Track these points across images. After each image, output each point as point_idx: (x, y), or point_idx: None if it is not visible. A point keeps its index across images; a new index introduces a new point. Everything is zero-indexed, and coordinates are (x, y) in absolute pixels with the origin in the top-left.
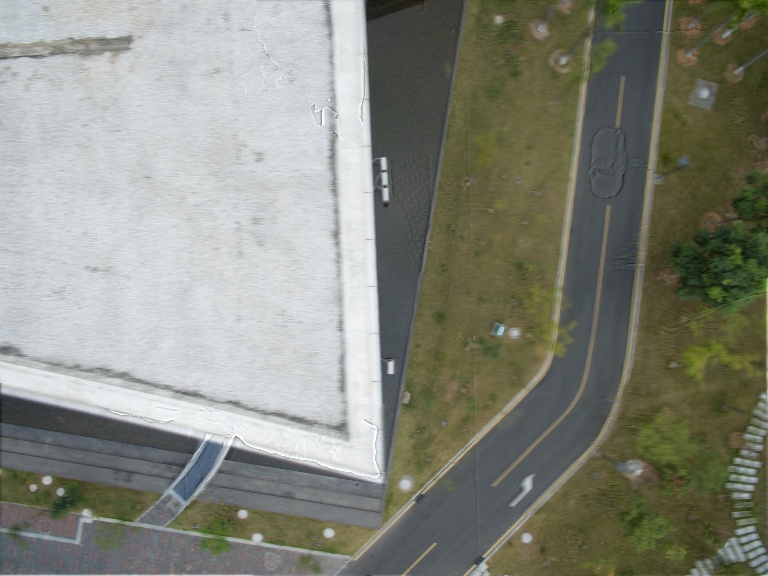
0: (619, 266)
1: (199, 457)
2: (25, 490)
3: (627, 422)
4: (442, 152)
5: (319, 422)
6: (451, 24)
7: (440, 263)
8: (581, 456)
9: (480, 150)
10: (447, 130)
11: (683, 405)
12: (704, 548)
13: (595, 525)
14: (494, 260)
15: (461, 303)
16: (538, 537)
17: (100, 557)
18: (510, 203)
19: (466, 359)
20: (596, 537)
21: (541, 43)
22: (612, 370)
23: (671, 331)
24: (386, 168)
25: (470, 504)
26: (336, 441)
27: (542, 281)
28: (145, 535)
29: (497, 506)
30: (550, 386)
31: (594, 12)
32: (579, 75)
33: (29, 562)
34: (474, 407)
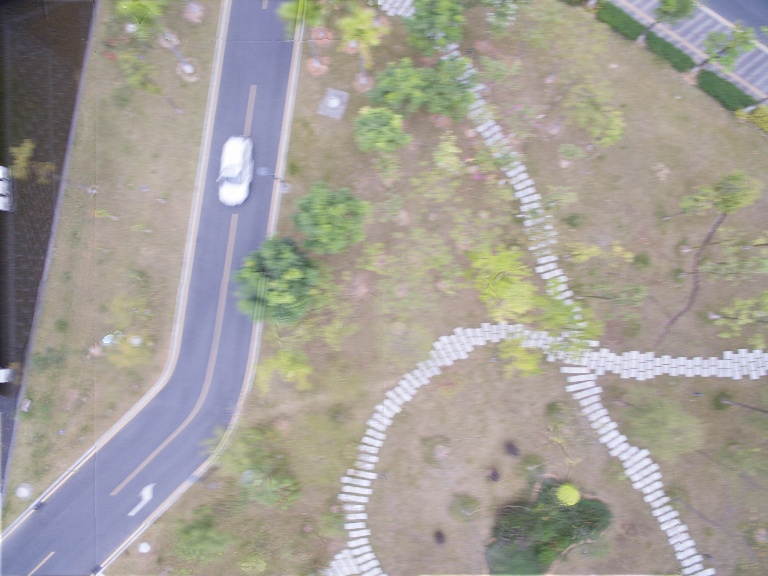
0: (244, 274)
1: None
2: None
3: (245, 431)
4: (68, 159)
5: None
6: (79, 32)
7: (65, 270)
8: (201, 465)
9: (108, 158)
10: (74, 138)
11: (300, 415)
12: (318, 560)
13: (213, 535)
14: (117, 268)
15: (84, 310)
16: (155, 547)
17: None
18: (135, 211)
19: (87, 367)
20: (214, 547)
21: (171, 52)
22: (233, 379)
23: (282, 340)
24: (4, 175)
25: (88, 513)
26: None
27: (165, 289)
28: None
29: (115, 515)
30: (171, 394)
31: (229, 21)
32: (207, 84)
33: None
34: (93, 415)
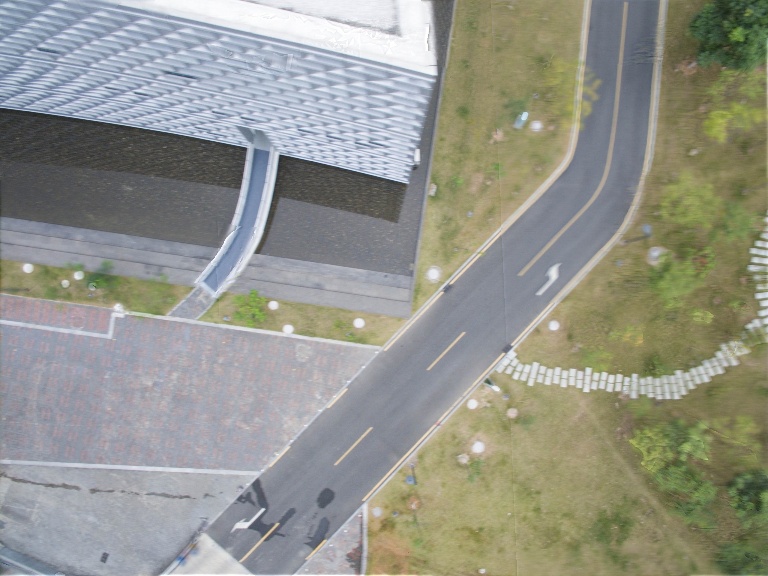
0: (638, 60)
1: (230, 247)
2: (57, 286)
3: (650, 209)
4: None
5: (372, 25)
6: None
7: (463, 60)
8: (605, 245)
9: None
10: None
11: (704, 191)
12: (729, 330)
13: (621, 311)
14: (516, 55)
15: (484, 98)
16: (565, 324)
17: (132, 351)
18: (530, 1)
19: (491, 151)
20: (622, 323)
21: None
22: (634, 160)
23: (691, 115)
24: None
25: (497, 293)
26: (390, 36)
27: (563, 75)
28: (177, 329)
29: (524, 294)
30: (573, 176)
31: None
32: None
33: (62, 358)
34: (499, 197)
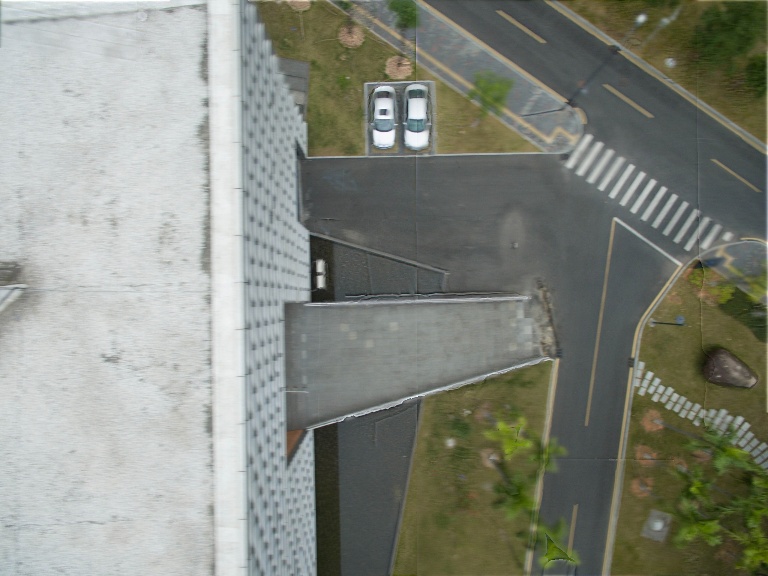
0: None
1: None
2: None
3: None
4: None
5: None
6: (403, 451)
7: None
8: None
9: None
10: (396, 557)
11: None
12: None
13: None
14: None
15: None
16: None
17: None
18: None
19: None
20: None
21: (493, 470)
22: None
23: None
24: None
25: None
26: None
27: None
28: None
29: None
30: None
31: (549, 435)
32: (531, 504)
33: None
34: None
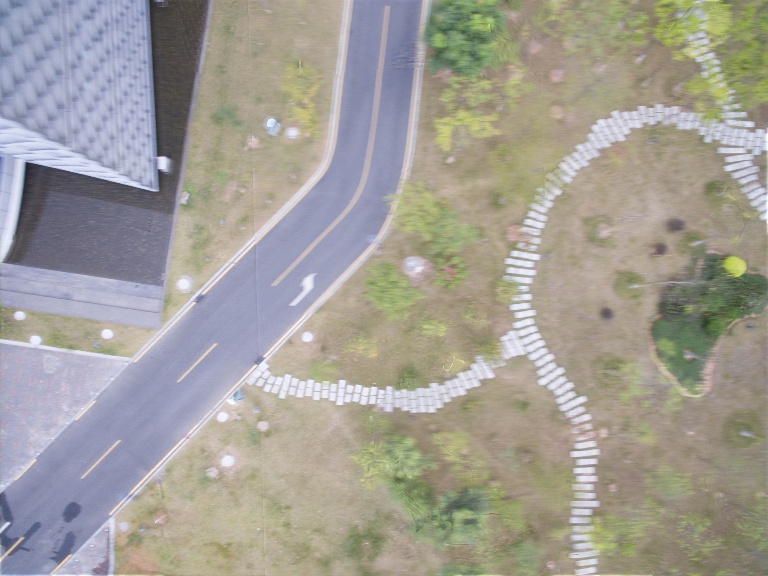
0: (398, 65)
1: None
2: None
3: (406, 218)
4: None
5: None
6: None
7: (219, 65)
8: (362, 254)
9: None
10: None
11: (461, 199)
12: (484, 342)
13: (376, 322)
14: (273, 60)
15: (240, 104)
16: (318, 336)
17: None
18: (288, 4)
19: (245, 159)
20: (377, 335)
21: None
22: (392, 168)
23: (444, 122)
24: None
25: (250, 304)
26: None
27: (321, 81)
28: None
29: (277, 305)
30: (330, 185)
31: None
32: None
33: None
34: (252, 206)
